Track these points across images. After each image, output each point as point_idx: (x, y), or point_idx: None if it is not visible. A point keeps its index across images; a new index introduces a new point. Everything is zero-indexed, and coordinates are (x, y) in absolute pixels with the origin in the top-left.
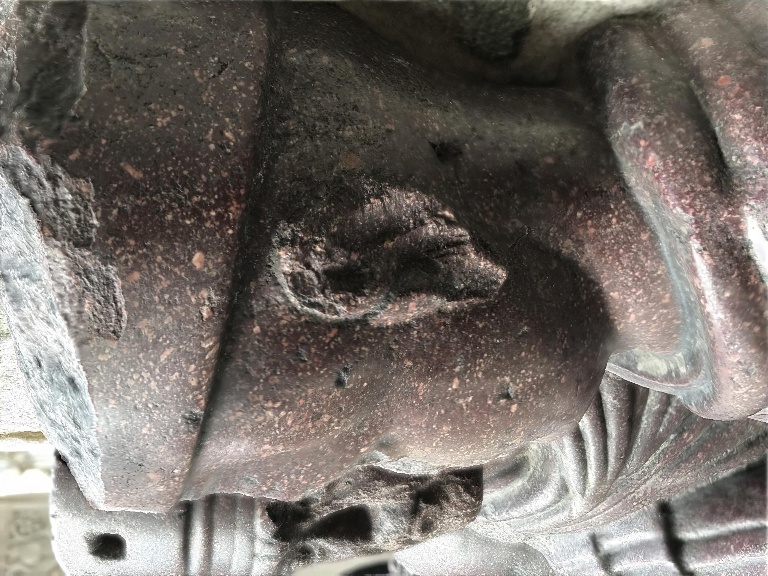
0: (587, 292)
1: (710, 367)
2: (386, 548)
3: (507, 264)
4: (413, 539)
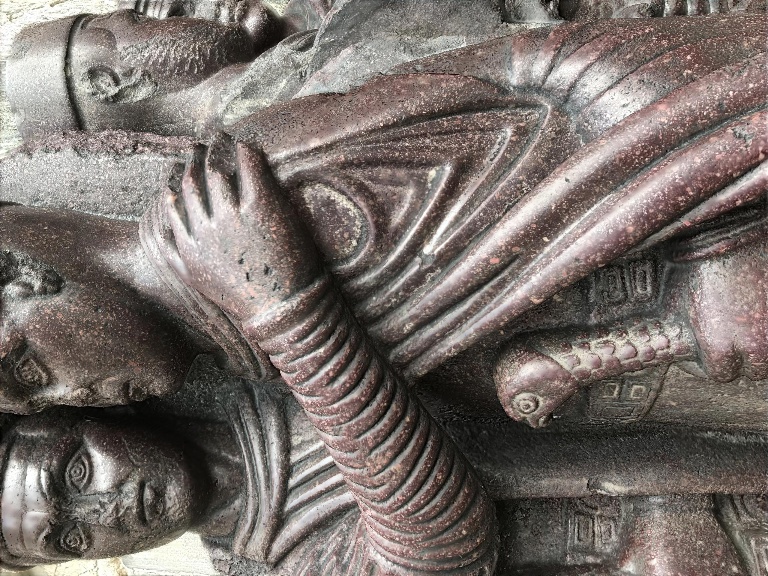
0: None
1: (301, 2)
2: None
3: None
4: None
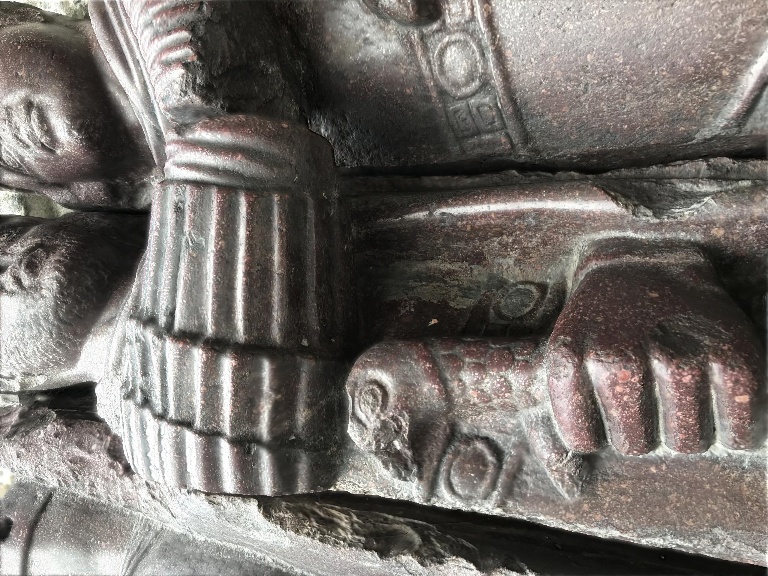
0: (80, 37)
1: None
2: (7, 288)
3: (48, 21)
4: (23, 284)
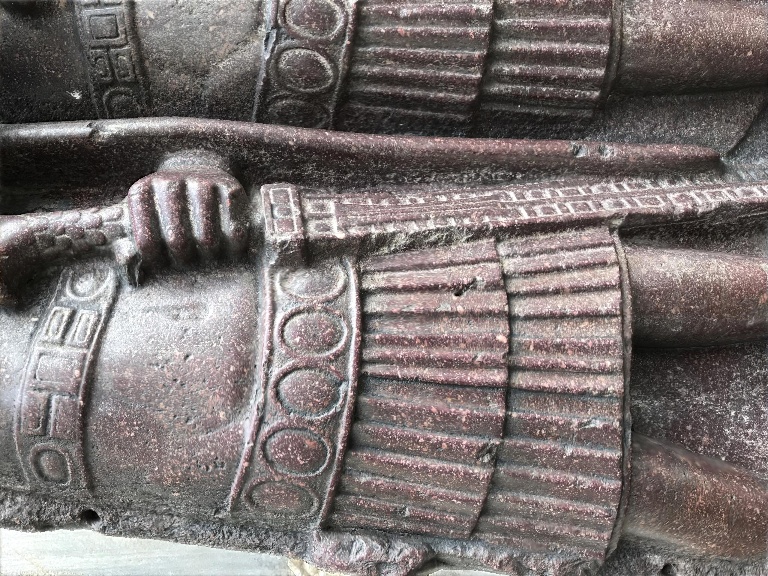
0: None
1: None
2: None
3: None
4: None
